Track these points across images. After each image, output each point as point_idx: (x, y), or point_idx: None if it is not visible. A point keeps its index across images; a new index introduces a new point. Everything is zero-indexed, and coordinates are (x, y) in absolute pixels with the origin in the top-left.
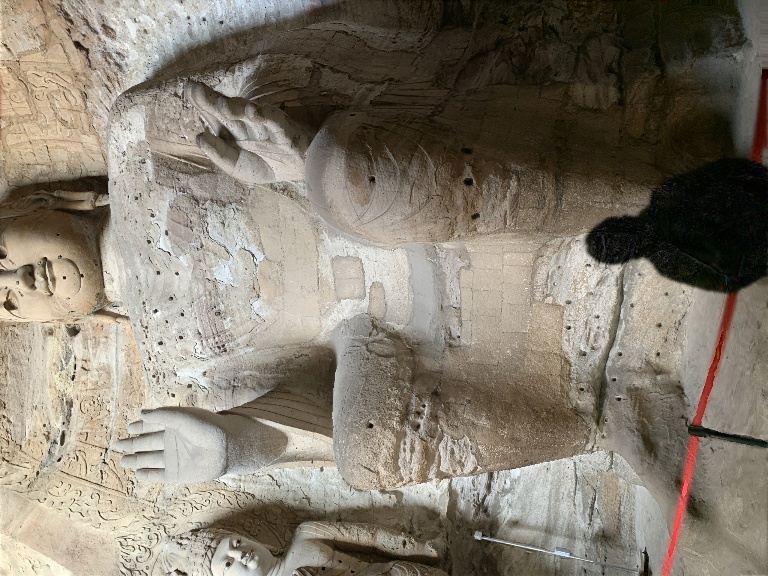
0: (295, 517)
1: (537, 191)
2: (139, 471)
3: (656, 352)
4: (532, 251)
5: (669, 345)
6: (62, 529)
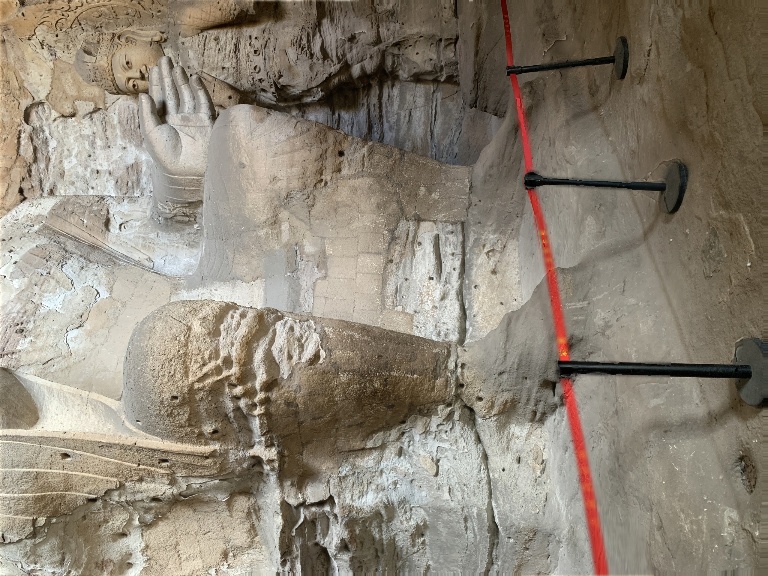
0: None
1: (387, 148)
2: None
3: None
4: (382, 252)
5: None
6: None
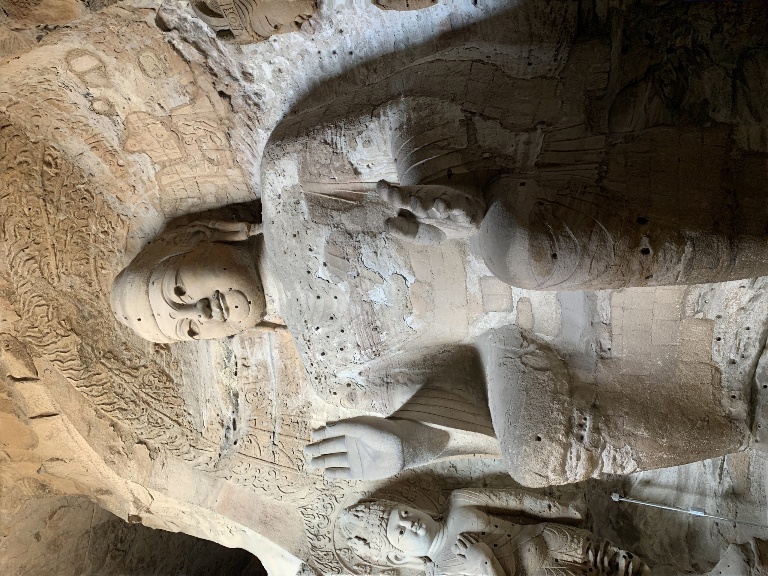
0: (445, 484)
1: (711, 254)
2: (328, 471)
3: None
4: None
5: None
6: (251, 502)
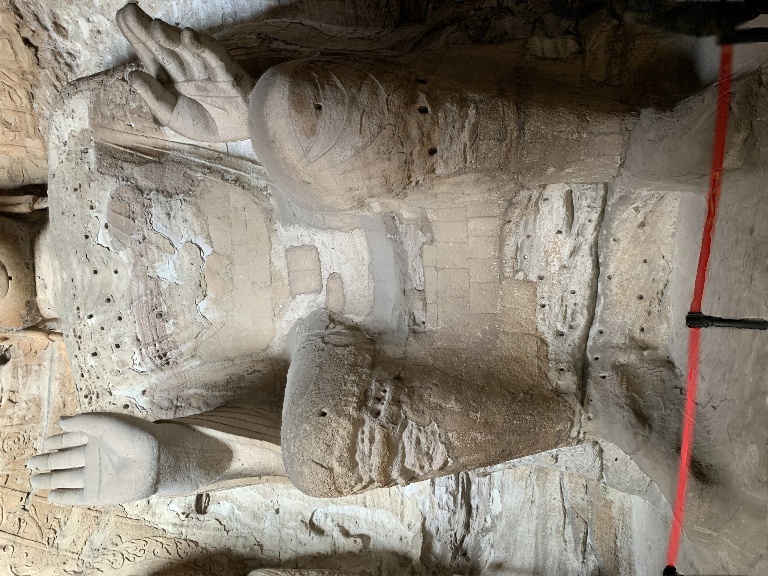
0: (244, 567)
1: (497, 120)
2: (53, 492)
3: (640, 327)
4: (498, 215)
5: (653, 318)
6: None
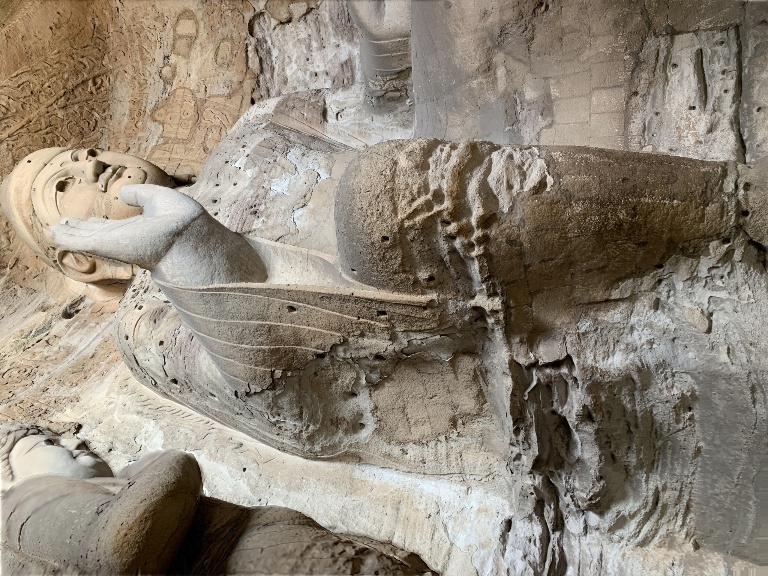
0: None
1: None
2: None
3: None
4: (623, 84)
5: None
6: None
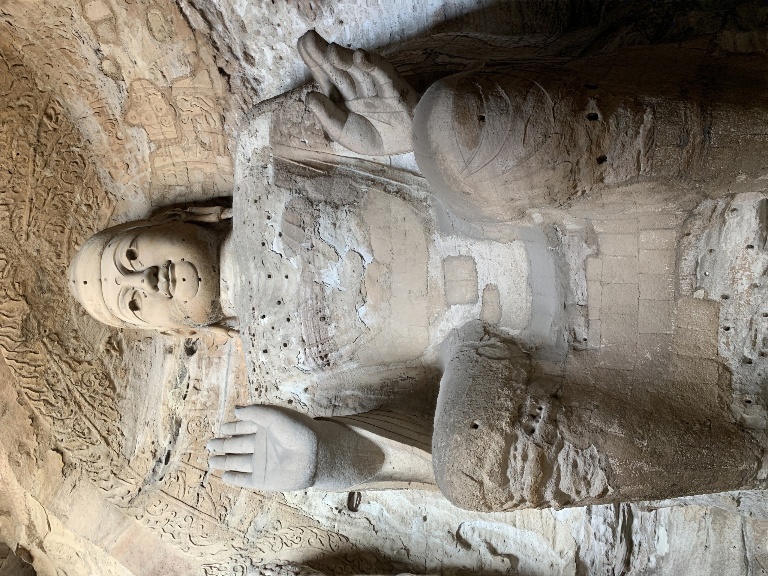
0: (391, 569)
1: (678, 124)
2: (227, 473)
3: None
4: (675, 227)
5: None
6: (152, 548)
